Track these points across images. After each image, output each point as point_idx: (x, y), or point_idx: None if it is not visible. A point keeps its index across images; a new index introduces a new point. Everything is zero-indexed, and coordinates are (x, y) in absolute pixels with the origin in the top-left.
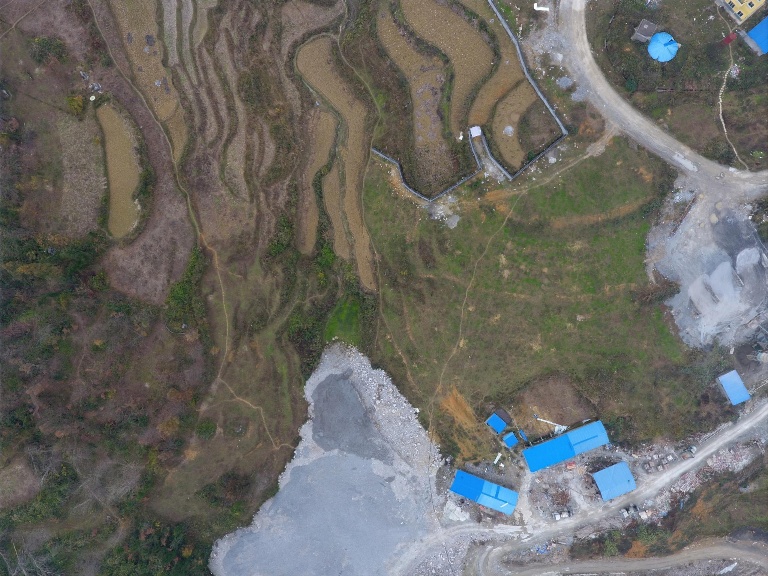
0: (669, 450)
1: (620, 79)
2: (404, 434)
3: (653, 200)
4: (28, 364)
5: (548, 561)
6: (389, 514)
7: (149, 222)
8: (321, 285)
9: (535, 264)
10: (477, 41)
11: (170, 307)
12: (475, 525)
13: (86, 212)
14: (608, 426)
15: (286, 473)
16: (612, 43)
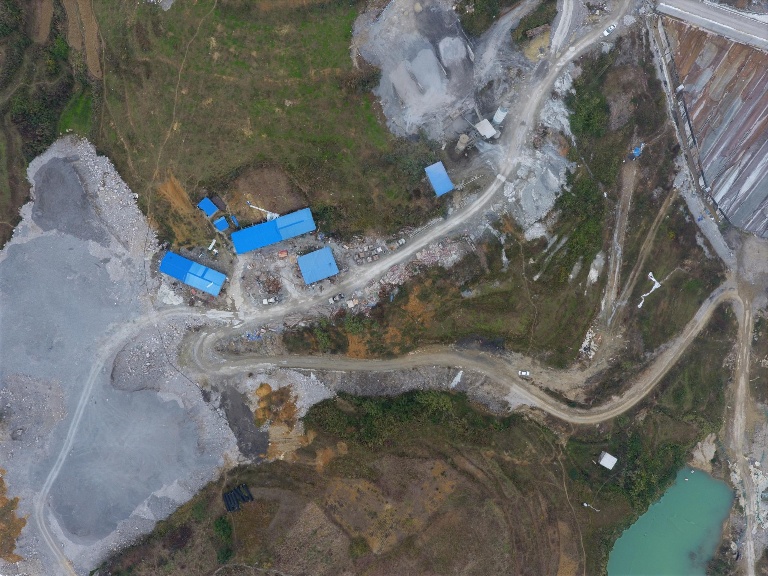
0: (381, 243)
1: None
2: (123, 219)
3: None
4: None
5: (264, 352)
6: (103, 294)
7: None
8: (49, 71)
9: (244, 47)
10: None
11: None
12: (188, 309)
13: None
14: (320, 216)
15: (3, 250)
16: None
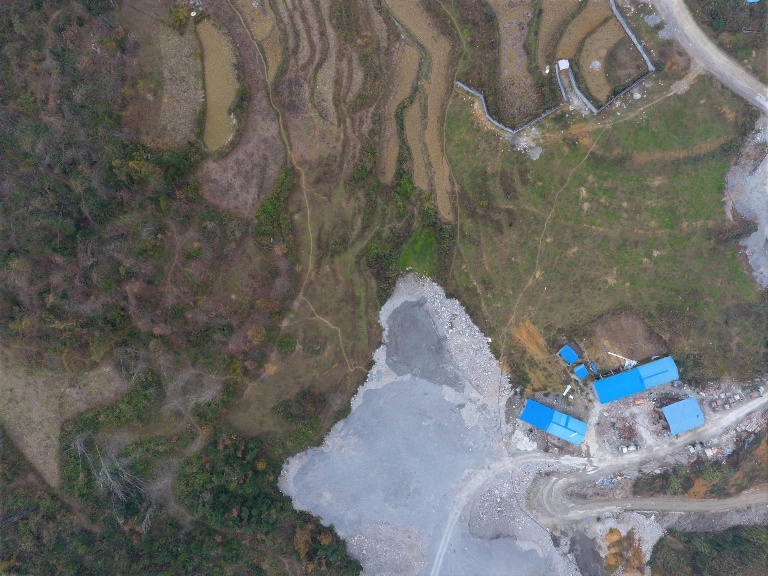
0: (736, 390)
1: (707, 19)
2: (475, 363)
3: (734, 139)
4: (131, 259)
5: (611, 496)
6: (458, 440)
7: (242, 137)
8: (400, 213)
9: (615, 198)
10: None
11: (259, 221)
12: (542, 455)
13: (184, 123)
14: (677, 363)
15: (359, 395)
16: None
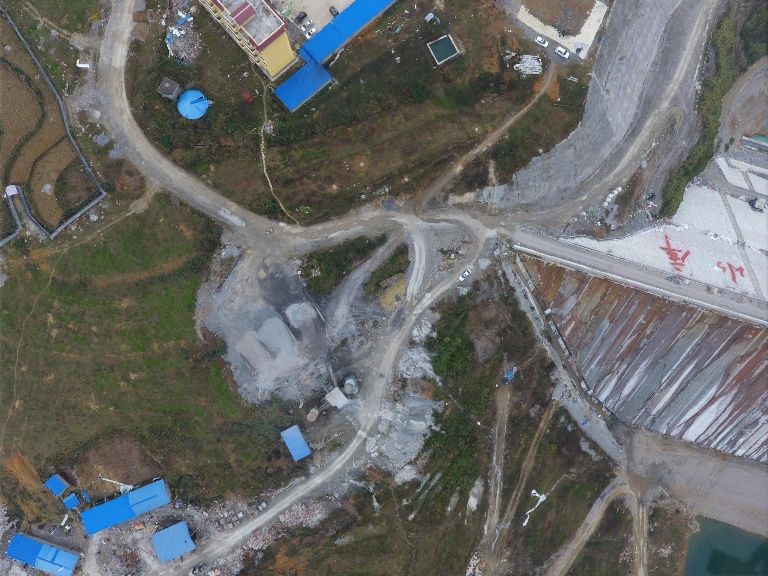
0: (242, 507)
1: (158, 136)
2: None
3: (196, 257)
4: None
5: None
6: None
7: None
8: None
9: (83, 323)
10: (27, 97)
11: None
12: None
13: None
14: (176, 484)
15: None
16: (144, 100)
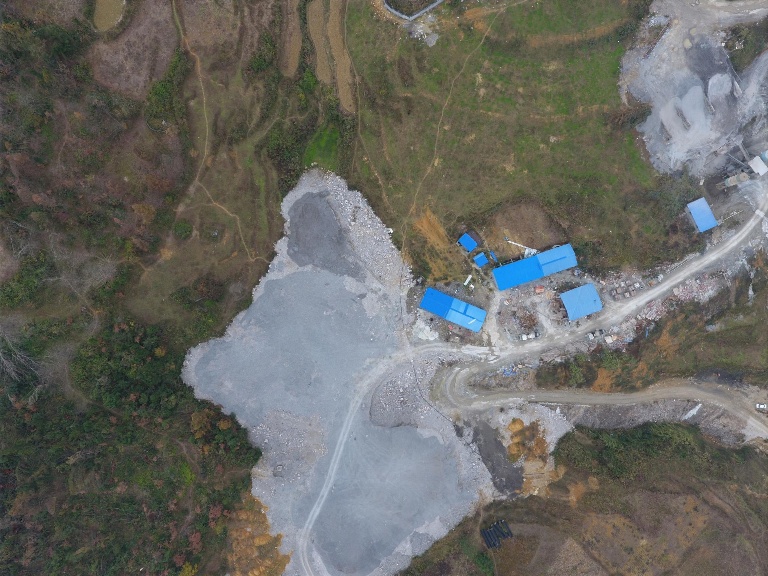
0: (637, 278)
1: None
2: (377, 254)
3: (628, 22)
4: (8, 125)
5: (514, 387)
6: (359, 330)
7: (134, 20)
8: (302, 106)
9: (511, 83)
10: None
11: (151, 103)
12: (443, 345)
13: (72, 2)
14: (577, 251)
15: (260, 285)
16: None
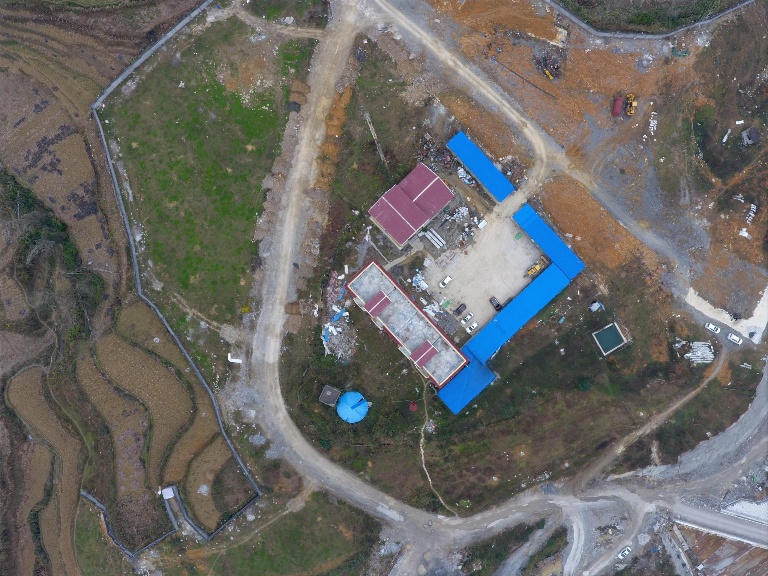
0: None
1: (315, 435)
2: None
3: (356, 556)
4: None
5: None
6: None
7: None
8: None
9: None
10: (176, 387)
11: None
12: None
13: None
14: None
15: None
16: (302, 402)
